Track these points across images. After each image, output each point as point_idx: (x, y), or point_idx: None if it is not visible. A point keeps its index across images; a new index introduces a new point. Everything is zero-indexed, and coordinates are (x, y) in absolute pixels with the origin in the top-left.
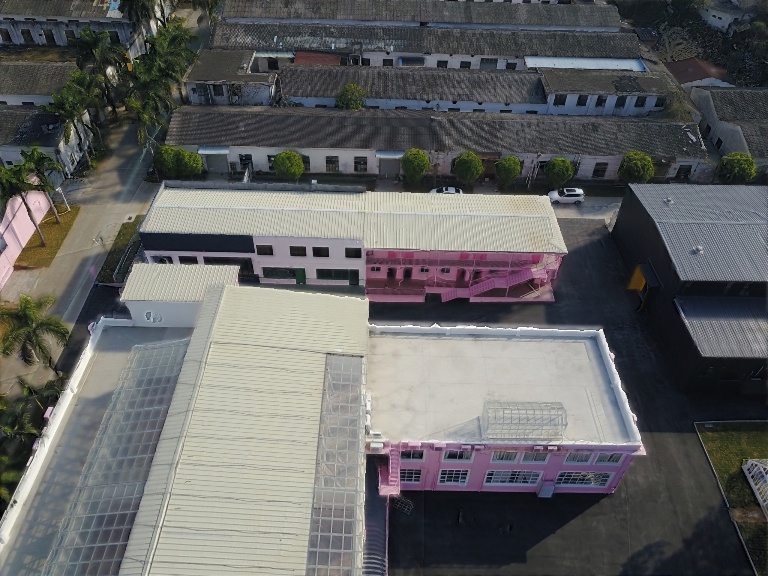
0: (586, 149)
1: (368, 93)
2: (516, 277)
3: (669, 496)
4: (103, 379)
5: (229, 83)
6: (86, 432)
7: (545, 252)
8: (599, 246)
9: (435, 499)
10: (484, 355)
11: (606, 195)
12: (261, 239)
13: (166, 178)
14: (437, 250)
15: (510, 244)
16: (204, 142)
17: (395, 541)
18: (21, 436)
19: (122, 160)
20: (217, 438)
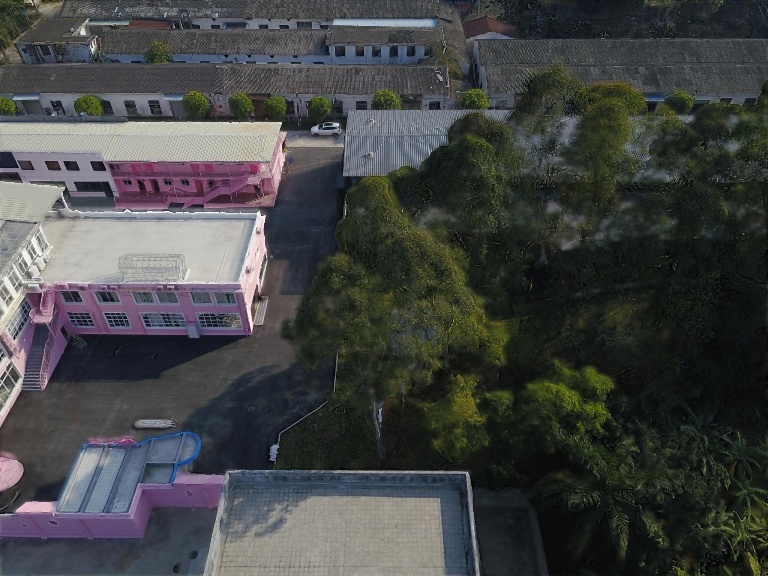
0: (344, 89)
1: (174, 50)
2: (237, 185)
3: None
4: None
5: (52, 43)
6: None
7: (252, 161)
8: (335, 166)
9: (108, 340)
10: (158, 231)
11: None
12: (20, 155)
13: None
14: (163, 161)
15: (225, 156)
16: (18, 90)
17: (62, 366)
18: None
19: None
20: None
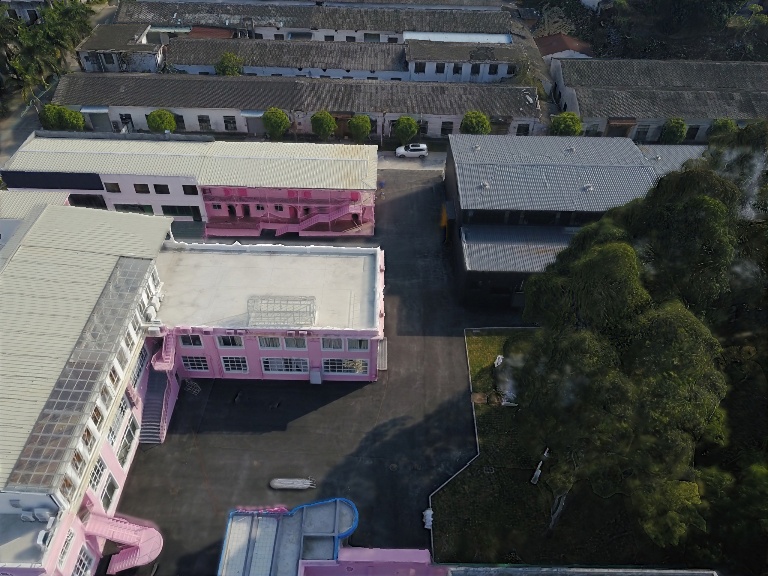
0: (431, 109)
1: (245, 61)
2: (337, 213)
3: (423, 383)
4: None
5: (117, 52)
6: None
7: (356, 189)
8: (429, 192)
9: (222, 385)
10: (274, 266)
11: None
12: (107, 177)
13: None
14: (262, 187)
15: (327, 182)
16: (86, 102)
17: (179, 414)
18: None
19: (18, 120)
20: (3, 312)
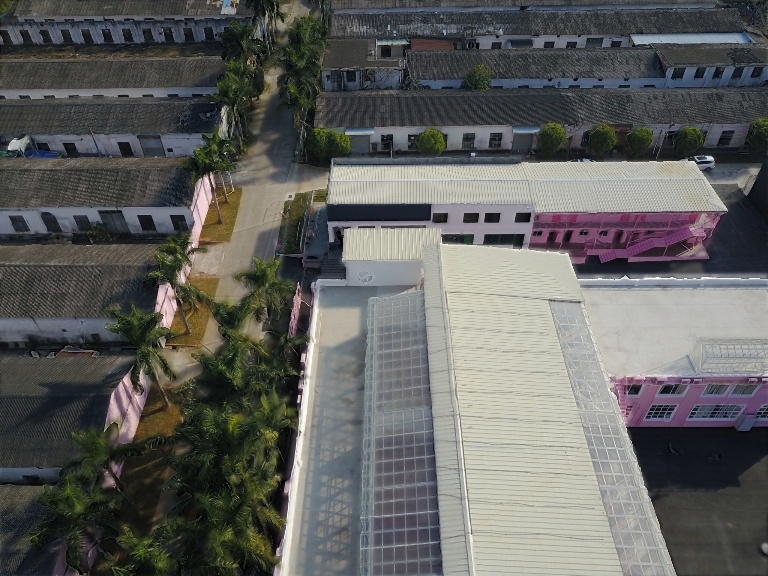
0: (714, 118)
1: (492, 74)
2: (674, 237)
3: None
4: (336, 331)
5: (363, 69)
6: (337, 375)
7: (706, 211)
8: (739, 208)
9: (641, 434)
10: (676, 303)
11: (733, 162)
12: (439, 207)
13: (314, 159)
14: (603, 212)
15: (672, 205)
16: (350, 124)
17: None
18: (283, 379)
19: (267, 145)
20: (481, 370)
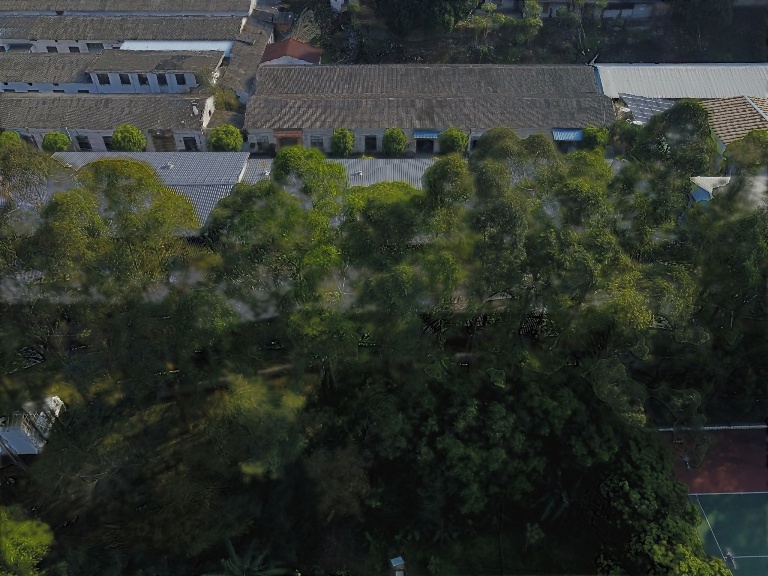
0: (87, 123)
1: None
2: None
3: None
4: None
5: None
6: None
7: None
8: None
9: None
10: None
11: None
12: None
13: None
14: None
15: None
16: None
17: None
18: None
19: None
20: None
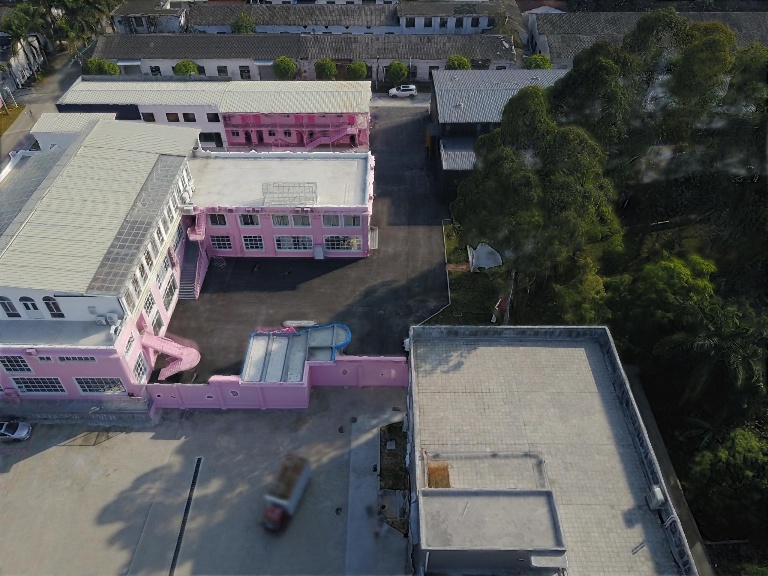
0: (419, 55)
1: (257, 21)
2: (336, 135)
3: (407, 258)
4: None
5: (146, 15)
6: None
7: (352, 112)
8: (417, 122)
9: (243, 261)
10: (283, 168)
11: None
12: (144, 107)
13: None
14: (273, 113)
15: (327, 108)
16: (122, 56)
17: (209, 281)
18: None
19: (63, 76)
20: (73, 188)
